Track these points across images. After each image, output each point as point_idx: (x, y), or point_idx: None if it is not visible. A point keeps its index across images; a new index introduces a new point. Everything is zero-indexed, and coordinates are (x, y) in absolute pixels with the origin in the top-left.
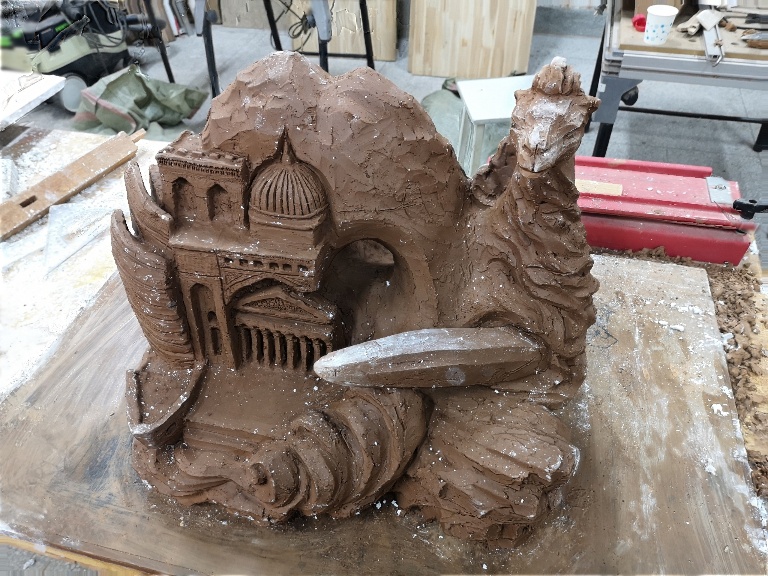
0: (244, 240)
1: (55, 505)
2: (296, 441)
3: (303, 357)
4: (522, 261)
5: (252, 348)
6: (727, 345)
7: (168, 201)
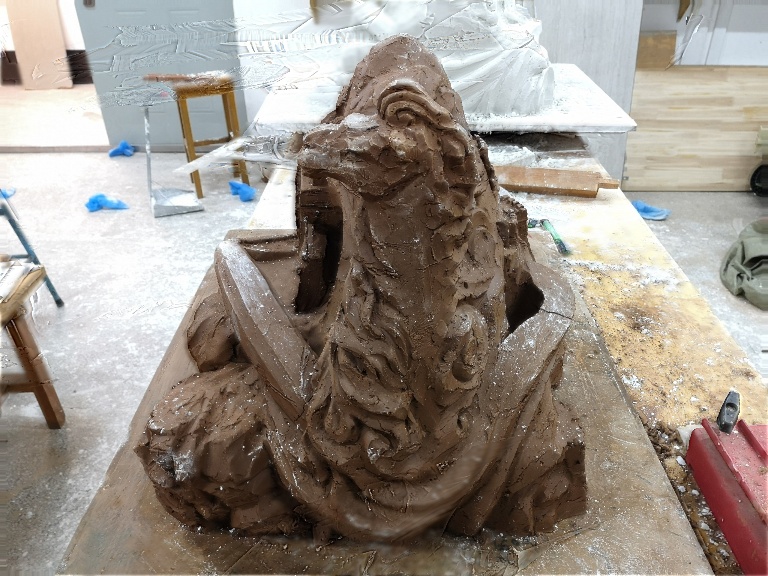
0: None
1: None
2: None
3: None
4: None
5: None
6: None
7: None
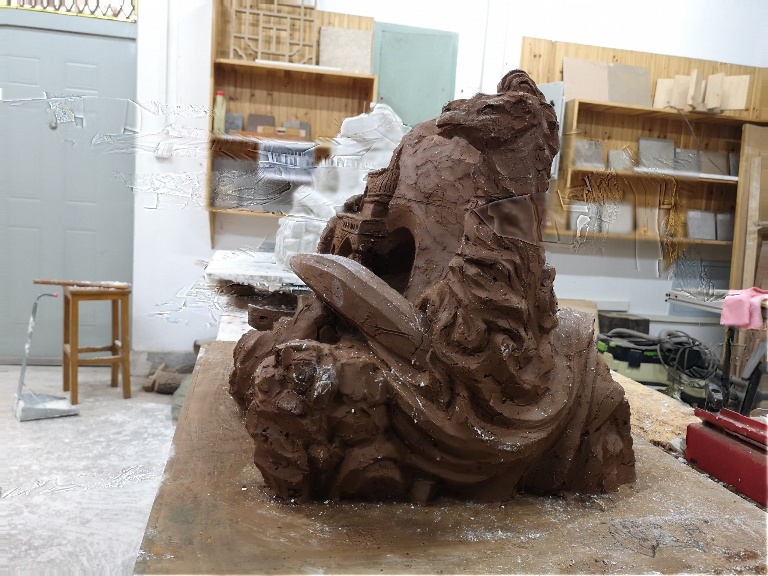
0: None
1: (219, 361)
2: None
3: None
4: None
5: None
6: None
7: None
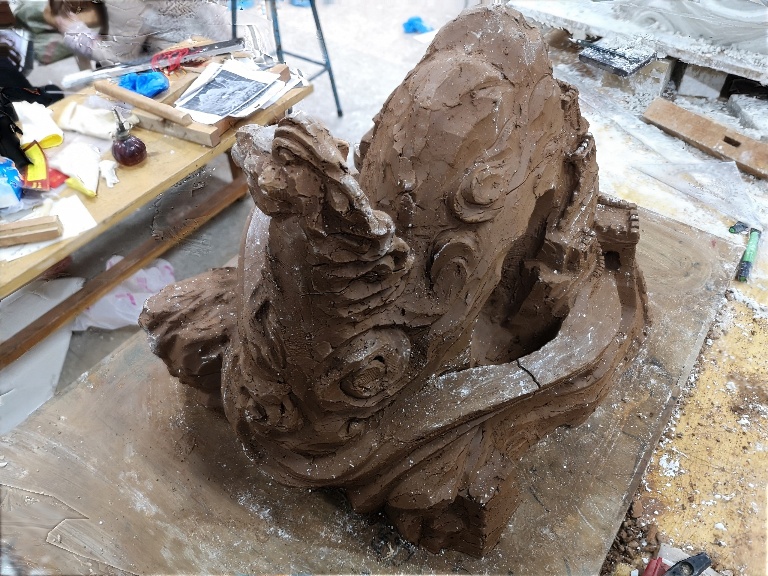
0: None
1: None
2: None
3: None
4: None
5: None
6: None
7: None
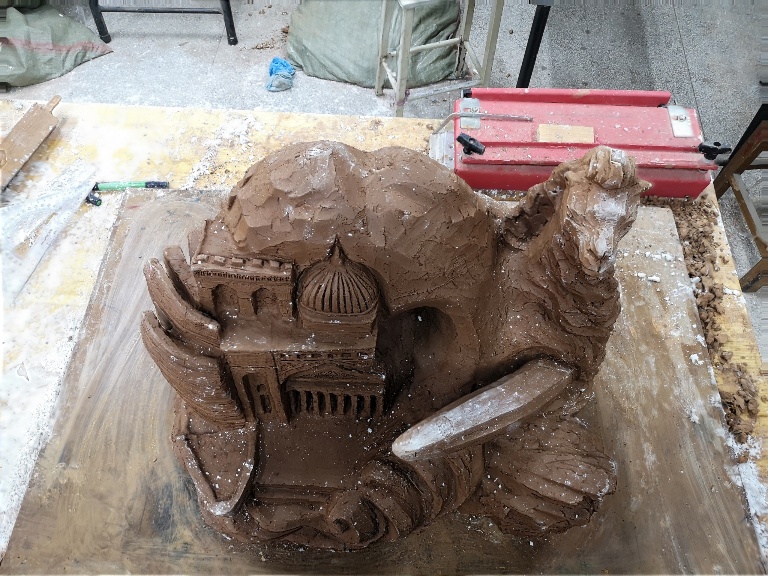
0: (298, 335)
1: (136, 565)
2: (369, 491)
3: (354, 406)
4: (560, 307)
5: (301, 403)
6: (696, 289)
7: (207, 303)
